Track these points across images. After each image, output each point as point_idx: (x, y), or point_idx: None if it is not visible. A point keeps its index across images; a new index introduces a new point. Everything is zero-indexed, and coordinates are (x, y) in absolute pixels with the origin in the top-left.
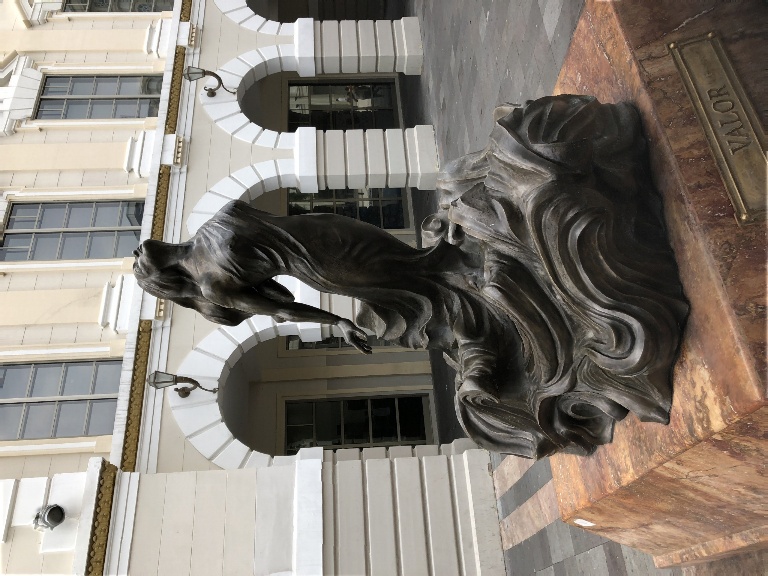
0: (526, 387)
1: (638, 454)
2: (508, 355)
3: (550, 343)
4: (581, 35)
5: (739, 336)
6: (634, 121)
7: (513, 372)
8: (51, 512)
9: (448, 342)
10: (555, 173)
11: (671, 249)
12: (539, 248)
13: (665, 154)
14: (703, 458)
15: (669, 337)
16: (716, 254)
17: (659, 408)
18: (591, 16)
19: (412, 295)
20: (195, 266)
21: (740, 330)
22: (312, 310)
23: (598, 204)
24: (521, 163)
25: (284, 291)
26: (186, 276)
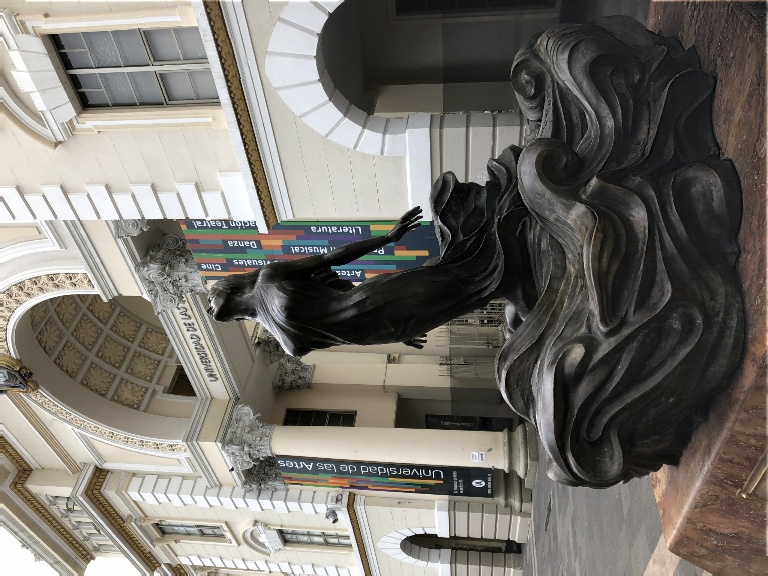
0: None
1: None
2: None
3: None
4: None
5: (679, 528)
6: (723, 379)
7: None
8: None
9: None
10: None
11: (691, 438)
12: None
13: (725, 423)
14: None
15: None
16: (702, 497)
17: None
18: None
19: None
20: None
21: (682, 527)
22: None
23: None
24: (551, 457)
25: None
26: None
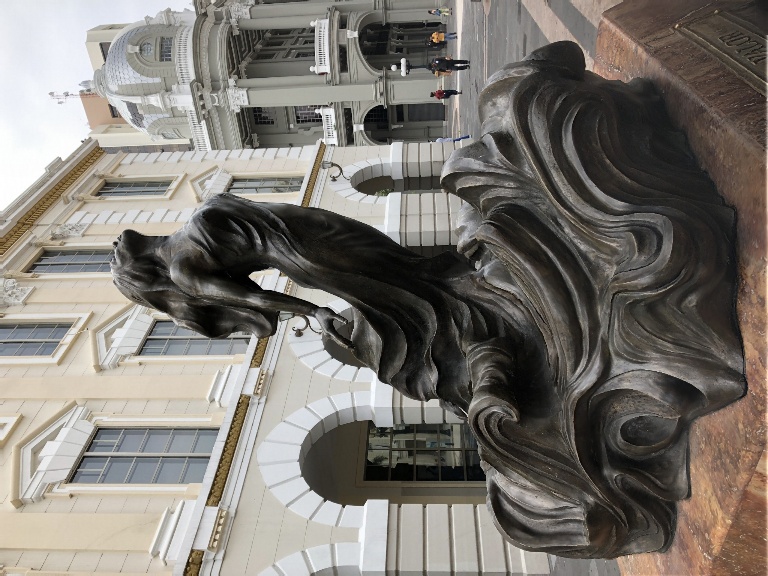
0: (556, 408)
1: (722, 478)
2: (530, 368)
3: (564, 294)
4: None
5: None
6: (643, 80)
7: (539, 391)
8: None
9: (466, 387)
10: (537, 67)
11: (703, 171)
12: (530, 154)
13: (679, 88)
14: None
15: (711, 238)
16: (750, 130)
17: (728, 370)
18: (601, 54)
19: (411, 301)
20: (169, 250)
21: None
22: None
23: (590, 89)
24: (503, 75)
25: None
26: (160, 267)
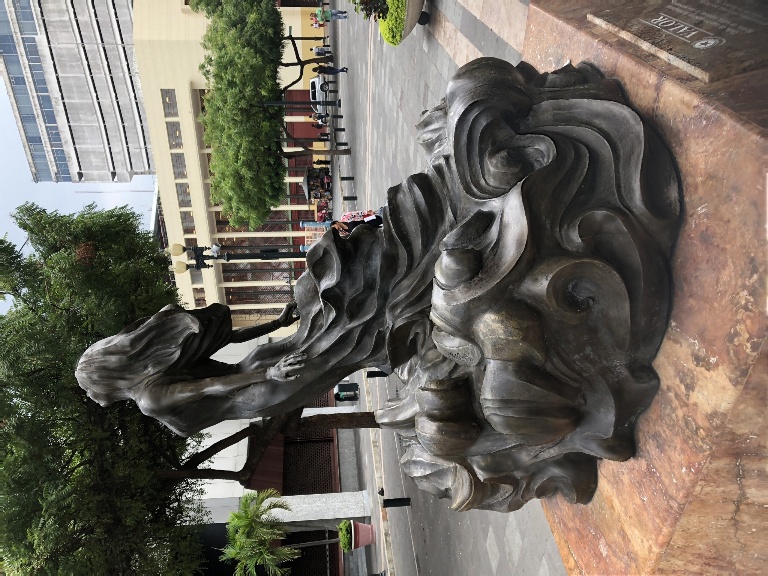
0: None
1: None
2: None
3: None
4: None
5: None
6: None
7: None
8: None
9: None
10: None
11: None
12: None
13: None
14: None
15: None
16: None
17: None
18: None
19: None
20: None
21: None
22: None
23: None
24: None
25: None
26: None
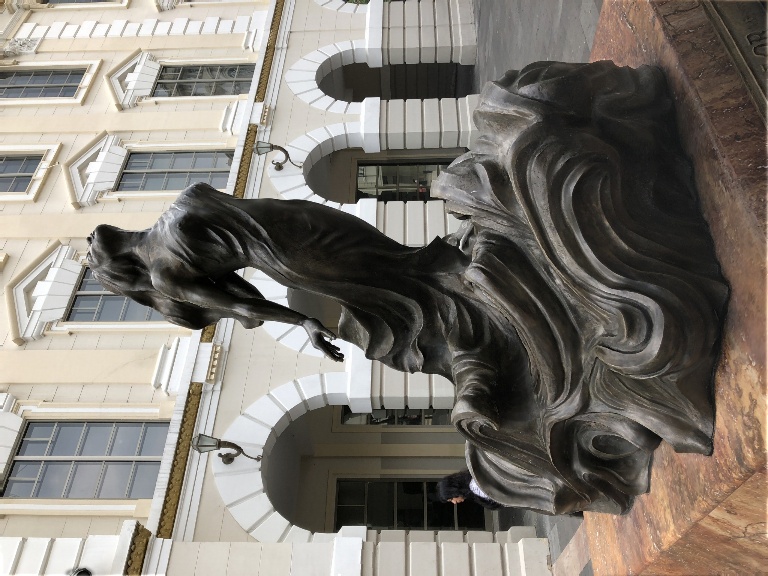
0: (535, 414)
1: (679, 503)
2: (513, 373)
3: (551, 343)
4: (605, 16)
5: None
6: (656, 79)
7: (519, 395)
8: (78, 575)
9: (450, 364)
10: (541, 113)
11: (705, 221)
12: (526, 211)
13: (693, 108)
14: (762, 502)
15: (701, 325)
16: (759, 212)
17: (698, 432)
18: None
19: (398, 298)
20: (147, 253)
21: None
22: (274, 306)
23: (596, 149)
24: (502, 108)
25: (251, 289)
26: (140, 266)
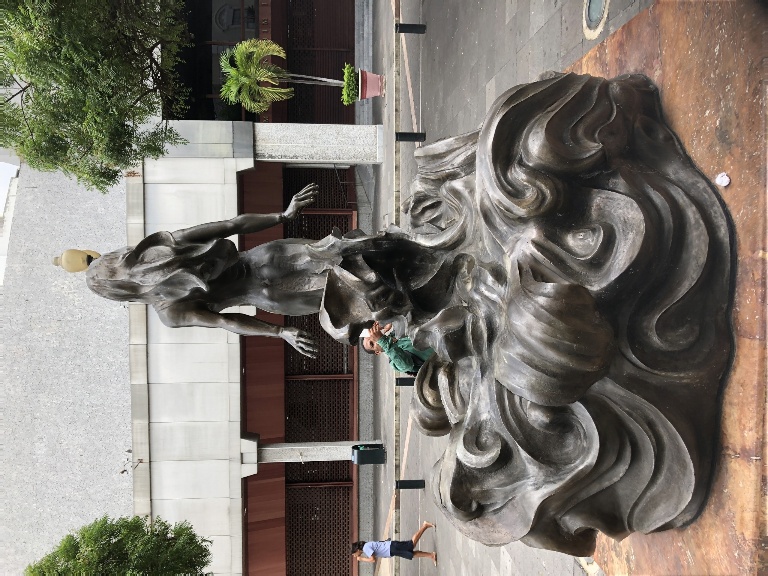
0: None
1: None
2: None
3: None
4: None
5: None
6: None
7: None
8: None
9: None
10: None
11: None
12: None
13: None
14: None
15: None
16: None
17: None
18: None
19: None
20: None
21: None
22: None
23: None
24: None
25: None
26: None
